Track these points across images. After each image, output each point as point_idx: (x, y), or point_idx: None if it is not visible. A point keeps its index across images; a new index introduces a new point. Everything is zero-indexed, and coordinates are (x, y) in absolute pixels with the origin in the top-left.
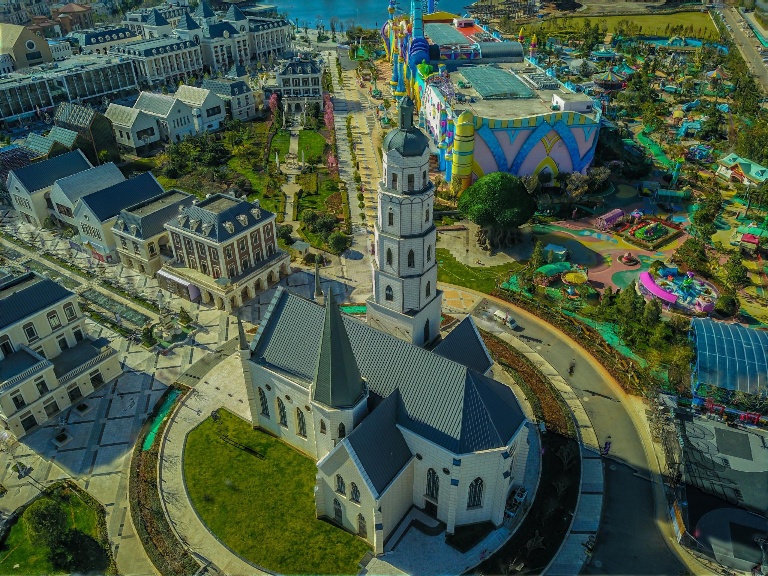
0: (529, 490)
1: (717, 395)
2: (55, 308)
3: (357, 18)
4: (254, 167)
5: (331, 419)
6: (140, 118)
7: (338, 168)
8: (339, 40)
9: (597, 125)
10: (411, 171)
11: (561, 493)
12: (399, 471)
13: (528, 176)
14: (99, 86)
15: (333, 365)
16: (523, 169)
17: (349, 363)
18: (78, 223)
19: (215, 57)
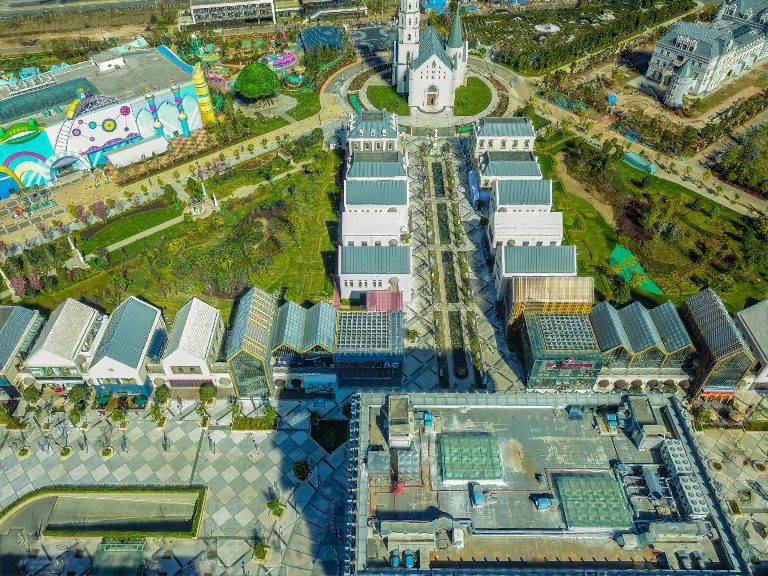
0: None
1: None
2: None
3: None
4: None
5: None
6: None
7: None
8: None
9: None
10: None
11: None
12: None
13: (217, 78)
14: None
15: None
16: None
17: None
18: None
19: None
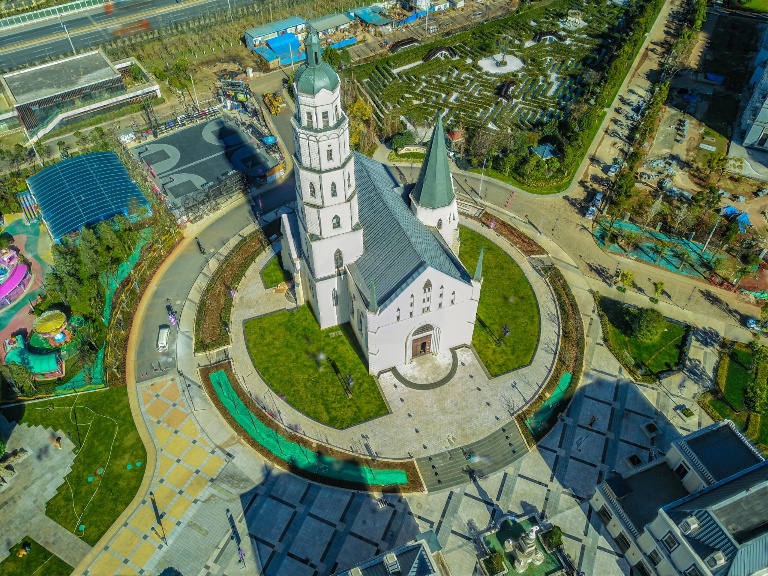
0: None
1: None
2: None
3: None
4: None
5: None
6: None
7: None
8: None
9: None
10: None
11: None
12: None
13: None
14: None
15: None
16: None
17: None
18: None
19: None
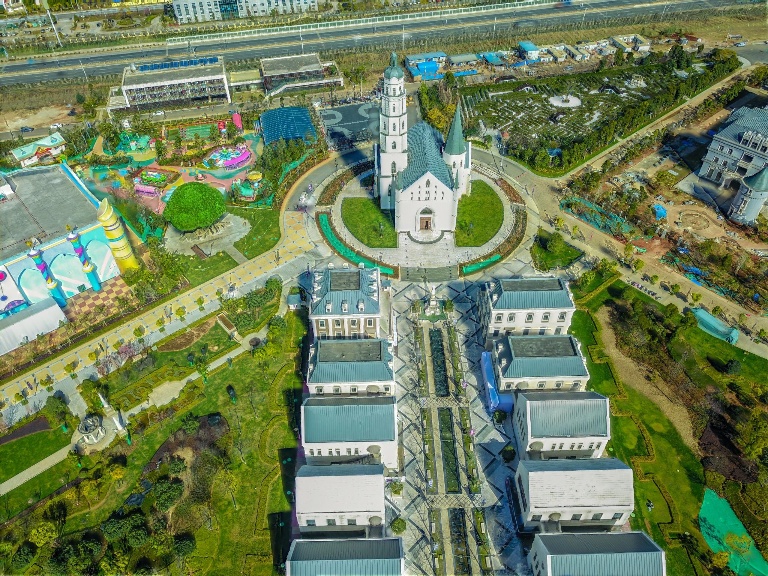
0: None
1: None
2: None
3: None
4: None
5: None
6: None
7: None
8: None
9: None
10: None
11: None
12: None
13: (141, 202)
14: None
15: None
16: None
17: None
18: None
19: None
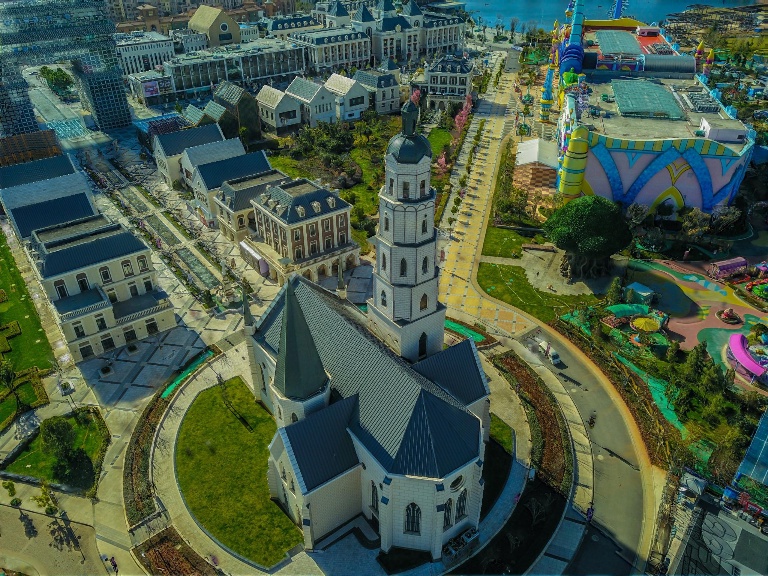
0: (487, 534)
1: (756, 493)
2: (129, 258)
3: (541, 20)
4: (372, 159)
5: (284, 407)
6: (285, 101)
7: (452, 170)
8: (517, 41)
9: (739, 158)
10: (406, 178)
11: (512, 546)
12: (338, 474)
13: (637, 205)
14: (270, 68)
15: (288, 355)
16: (641, 197)
17: (305, 357)
18: (194, 188)
19: (384, 49)
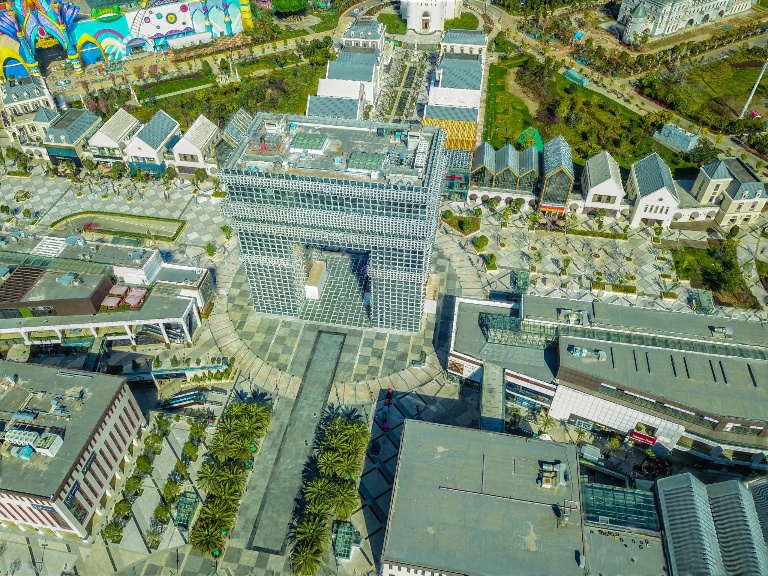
0: None
1: None
2: None
3: None
4: None
5: None
6: None
7: None
8: None
9: None
10: None
11: None
12: None
13: None
14: None
15: None
16: None
17: None
18: None
19: None
